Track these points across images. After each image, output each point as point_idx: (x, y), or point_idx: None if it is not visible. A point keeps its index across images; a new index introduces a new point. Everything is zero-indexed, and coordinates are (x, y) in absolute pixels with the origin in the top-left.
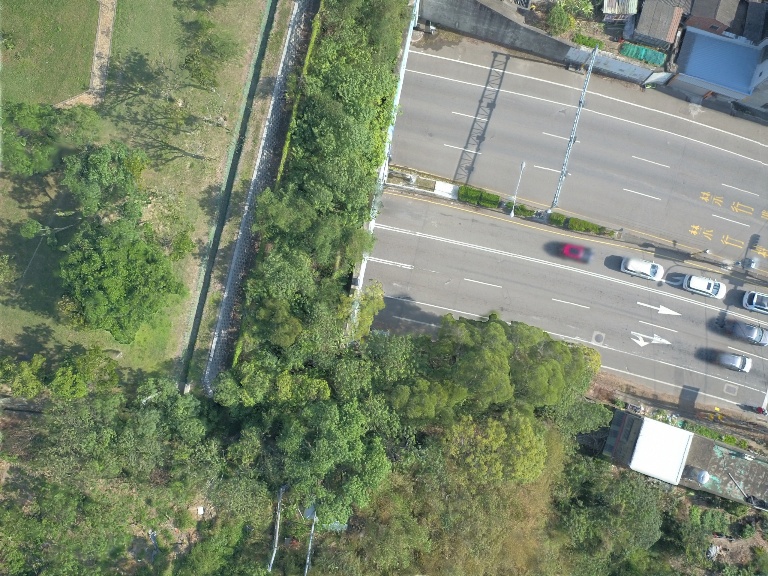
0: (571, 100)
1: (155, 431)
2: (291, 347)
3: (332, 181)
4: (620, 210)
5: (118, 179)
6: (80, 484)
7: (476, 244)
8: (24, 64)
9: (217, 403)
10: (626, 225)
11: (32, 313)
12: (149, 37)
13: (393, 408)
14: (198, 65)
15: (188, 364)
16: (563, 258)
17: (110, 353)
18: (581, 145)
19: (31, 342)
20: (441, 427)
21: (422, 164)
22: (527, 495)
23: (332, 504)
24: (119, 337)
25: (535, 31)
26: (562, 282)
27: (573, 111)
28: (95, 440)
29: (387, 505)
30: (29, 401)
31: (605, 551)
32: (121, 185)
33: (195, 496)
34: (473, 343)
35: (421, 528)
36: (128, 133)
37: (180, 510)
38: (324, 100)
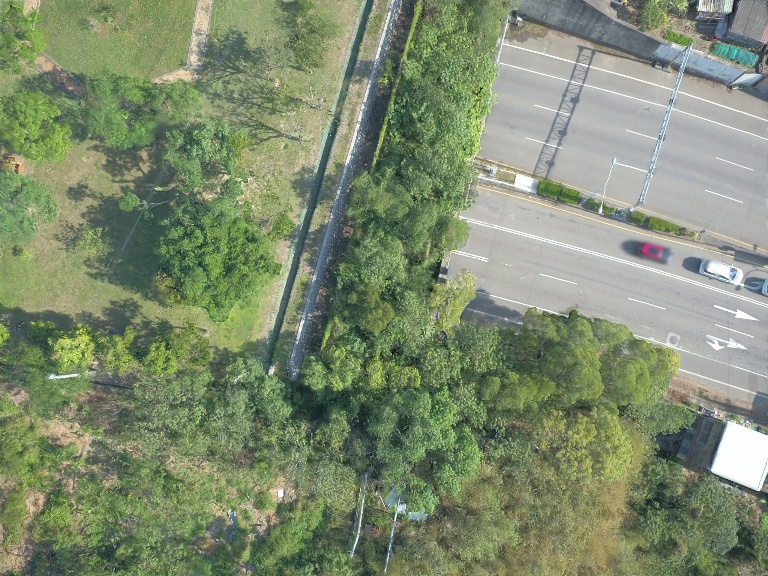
0: (656, 98)
1: (244, 411)
2: (381, 333)
3: (432, 168)
4: (701, 211)
5: (221, 156)
6: (162, 461)
7: (553, 239)
8: (122, 37)
9: (299, 386)
10: (706, 227)
11: (120, 287)
12: (248, 15)
13: (482, 399)
14: (303, 45)
15: (273, 346)
16: (641, 257)
17: (197, 331)
18: (664, 144)
19: (118, 316)
20: (523, 421)
21: (502, 156)
22: (607, 494)
23: (422, 492)
24: (215, 315)
25: (627, 26)
26: (639, 281)
27: (658, 109)
28: (186, 417)
29: (476, 496)
30: (114, 375)
31: (680, 554)
32: (215, 163)
33: (277, 478)
34: (559, 338)
35: (510, 521)
36: (224, 111)
37: (261, 491)
38: (425, 86)
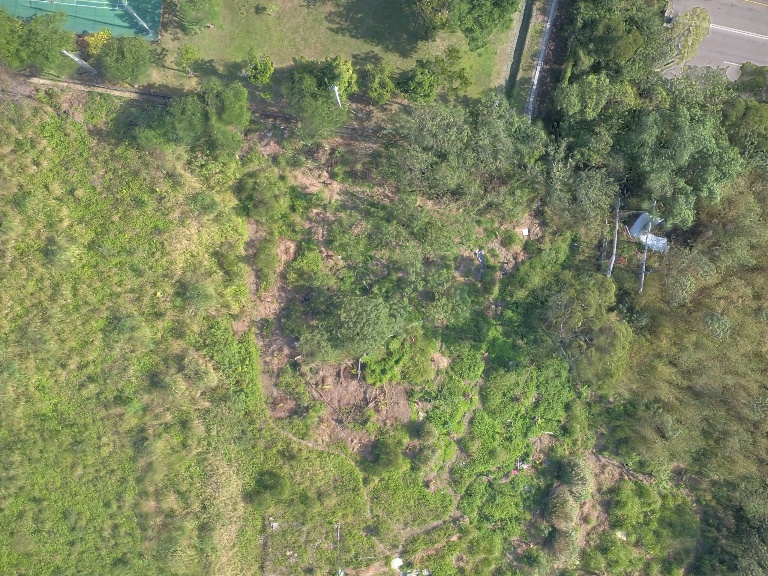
0: None
1: None
2: (625, 65)
3: None
4: None
5: None
6: None
7: (736, 28)
8: None
9: None
10: None
11: (361, 41)
12: None
13: (726, 124)
14: None
15: (509, 94)
16: None
17: None
18: None
19: None
20: None
21: None
22: None
23: (689, 196)
24: (479, 36)
25: None
26: None
27: None
28: (455, 135)
29: (739, 201)
30: (359, 124)
31: None
32: None
33: (524, 215)
34: None
35: None
36: None
37: (507, 230)
38: None
